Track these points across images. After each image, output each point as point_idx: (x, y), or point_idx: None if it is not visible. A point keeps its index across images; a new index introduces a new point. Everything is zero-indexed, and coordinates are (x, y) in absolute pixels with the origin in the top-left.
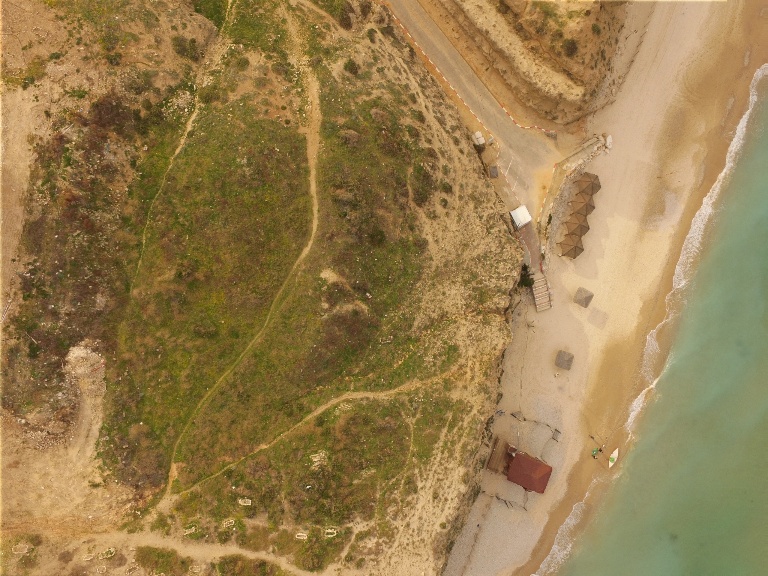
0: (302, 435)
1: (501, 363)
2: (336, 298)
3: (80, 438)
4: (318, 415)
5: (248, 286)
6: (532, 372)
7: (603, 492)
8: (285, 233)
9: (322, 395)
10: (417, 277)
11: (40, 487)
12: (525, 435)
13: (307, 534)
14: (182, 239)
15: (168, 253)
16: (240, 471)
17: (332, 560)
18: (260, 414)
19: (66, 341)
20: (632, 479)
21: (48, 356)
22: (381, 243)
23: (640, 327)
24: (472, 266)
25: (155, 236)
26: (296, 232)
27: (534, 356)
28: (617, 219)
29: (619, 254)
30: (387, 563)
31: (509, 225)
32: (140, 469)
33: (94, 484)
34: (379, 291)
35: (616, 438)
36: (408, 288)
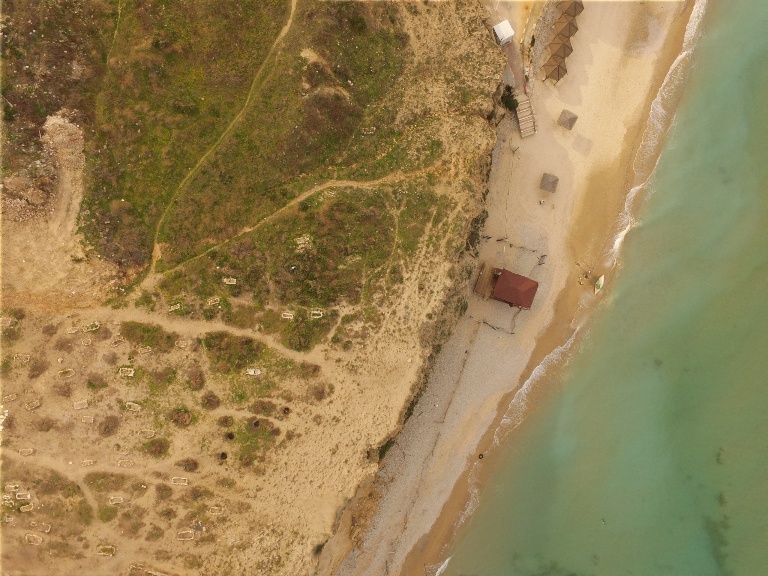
0: (286, 218)
1: (486, 182)
2: (317, 80)
3: (61, 212)
4: (302, 201)
5: (227, 63)
6: (517, 199)
7: (589, 318)
8: (264, 10)
9: (305, 182)
10: (399, 71)
11: (21, 260)
12: (511, 262)
13: (293, 314)
14: (158, 9)
15: (144, 22)
16: (224, 252)
17: (319, 341)
18: (243, 197)
19: (43, 108)
20: (618, 305)
21: (25, 121)
22: (362, 31)
23: (624, 154)
24: (454, 65)
25: (131, 6)
26: (275, 9)
27: (519, 183)
28: (600, 45)
29: (603, 81)
30: (374, 348)
31: (492, 35)
32: (123, 245)
33: (76, 259)
34: (361, 80)
35: (601, 265)
36: (390, 81)
